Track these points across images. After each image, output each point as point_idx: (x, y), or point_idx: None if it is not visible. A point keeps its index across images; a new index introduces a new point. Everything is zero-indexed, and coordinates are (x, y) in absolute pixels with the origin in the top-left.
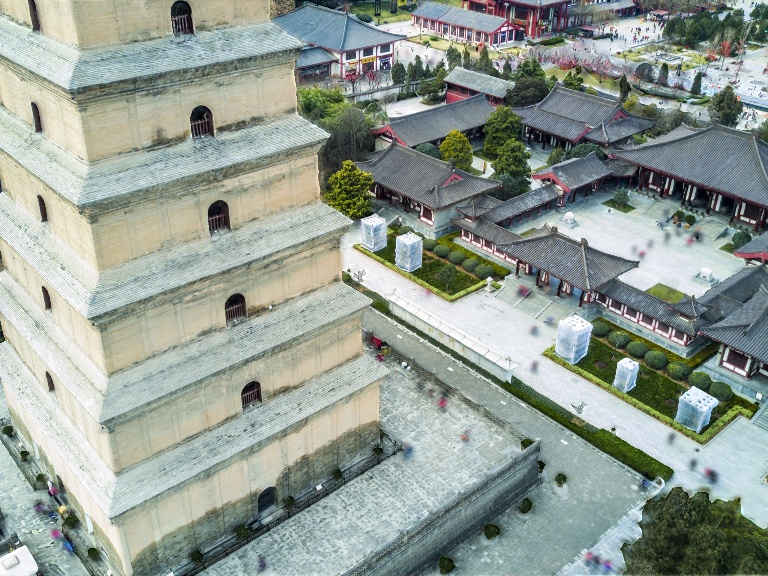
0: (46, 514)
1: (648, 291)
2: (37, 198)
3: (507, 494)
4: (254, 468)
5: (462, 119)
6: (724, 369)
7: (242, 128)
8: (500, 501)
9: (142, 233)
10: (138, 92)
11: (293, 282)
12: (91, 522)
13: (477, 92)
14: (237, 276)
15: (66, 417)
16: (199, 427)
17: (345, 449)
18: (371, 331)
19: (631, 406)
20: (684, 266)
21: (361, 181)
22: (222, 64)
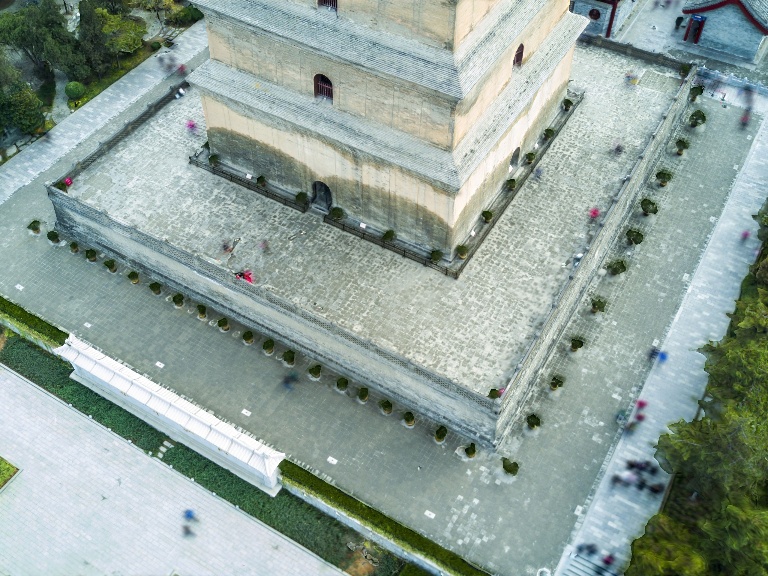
0: None
1: None
2: None
3: None
4: None
5: None
6: None
7: None
8: None
9: None
10: None
11: None
12: None
13: None
14: None
15: None
16: None
17: None
18: (263, 286)
19: None
20: None
21: None
22: None
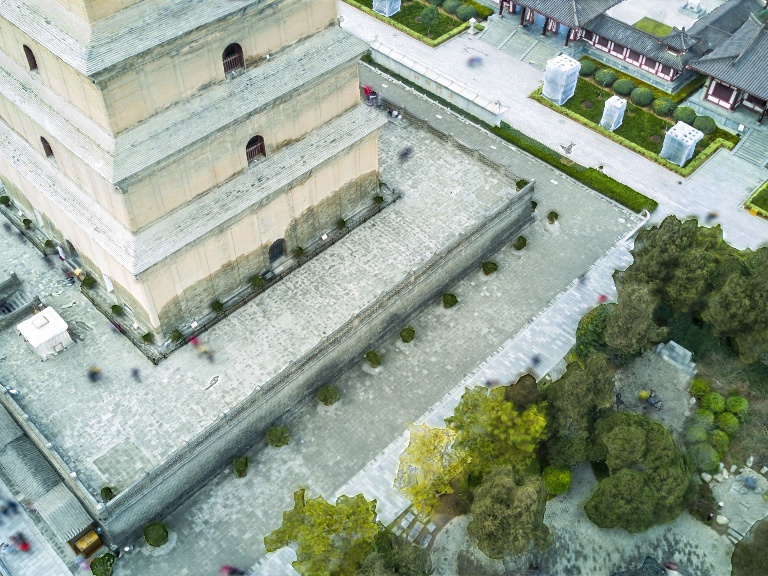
0: (62, 277)
1: (634, 26)
2: None
3: (503, 233)
4: (263, 221)
5: None
6: (709, 103)
7: None
8: (496, 240)
9: None
10: None
11: (289, 28)
12: (110, 281)
13: None
14: (232, 23)
15: (70, 182)
16: (208, 184)
17: (347, 199)
18: None
19: (617, 144)
20: None
21: None
22: None
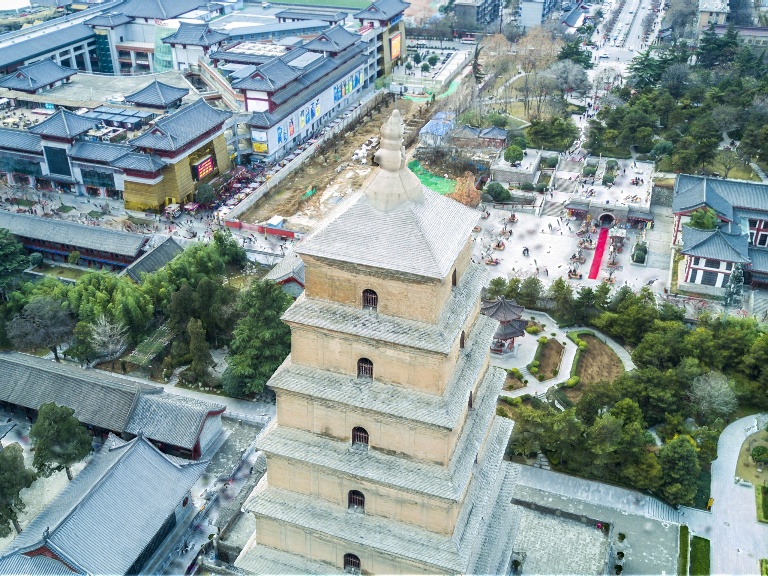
0: None
1: None
2: None
3: None
4: None
5: None
6: None
7: (392, 455)
8: None
9: (299, 480)
10: (316, 401)
11: None
12: None
13: None
14: None
15: None
16: None
17: None
18: None
19: None
20: None
21: None
22: (377, 411)
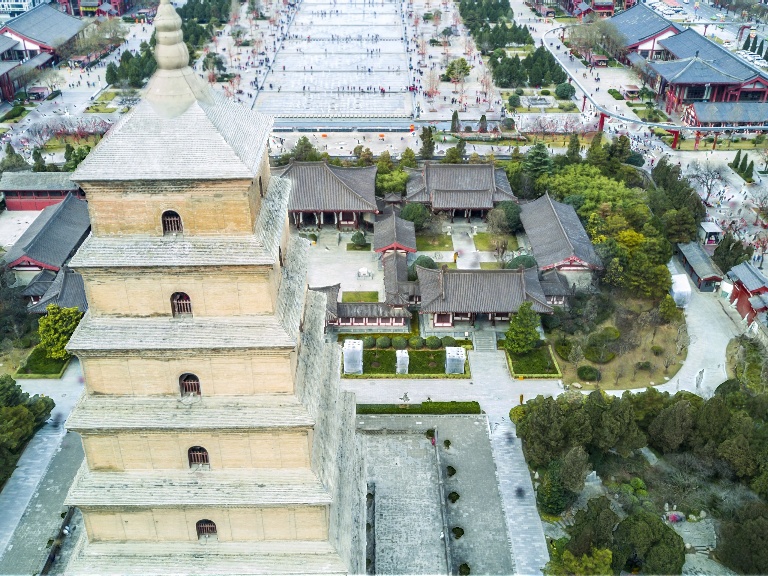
0: None
1: (344, 301)
2: (187, 450)
3: None
4: None
5: (73, 223)
6: (437, 328)
7: None
8: None
9: None
10: None
11: None
12: None
13: (45, 191)
14: None
15: None
16: None
17: None
18: None
19: (417, 380)
20: (343, 273)
21: (74, 318)
22: None
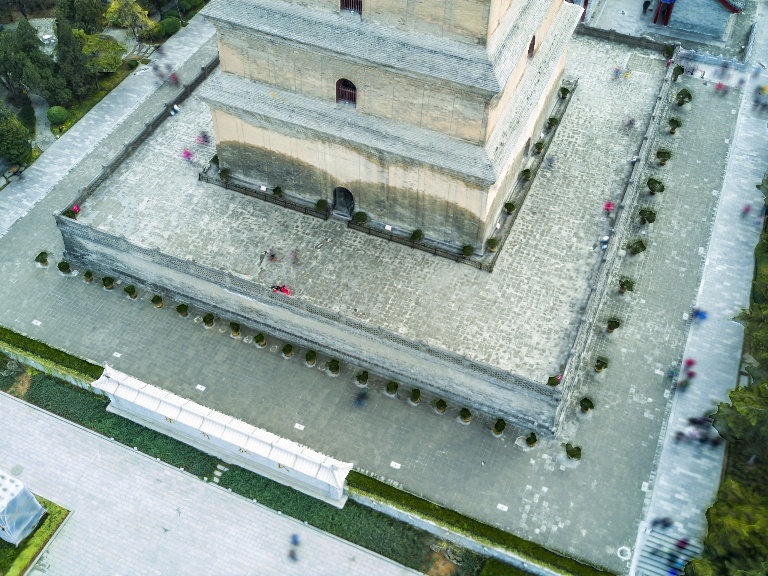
0: None
1: None
2: None
3: None
4: None
5: None
6: None
7: None
8: None
9: None
10: None
11: None
12: None
13: None
14: None
15: None
16: None
17: None
18: (302, 297)
19: None
20: None
21: None
22: None
